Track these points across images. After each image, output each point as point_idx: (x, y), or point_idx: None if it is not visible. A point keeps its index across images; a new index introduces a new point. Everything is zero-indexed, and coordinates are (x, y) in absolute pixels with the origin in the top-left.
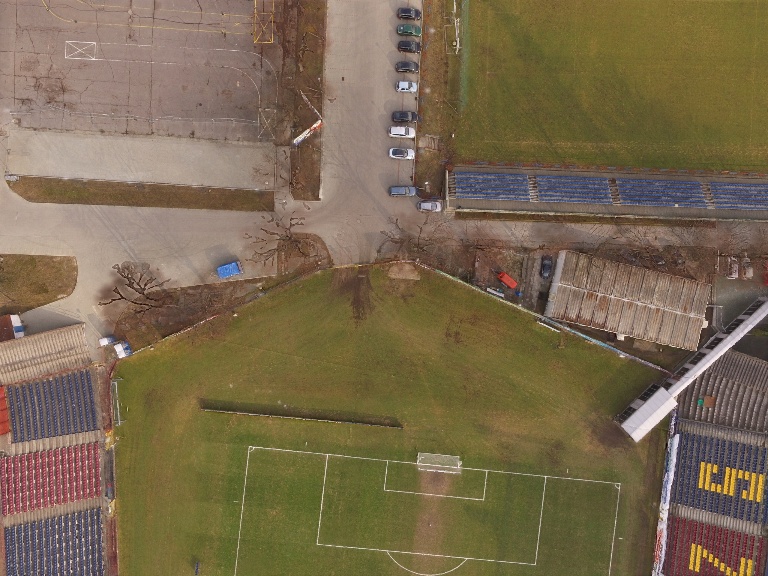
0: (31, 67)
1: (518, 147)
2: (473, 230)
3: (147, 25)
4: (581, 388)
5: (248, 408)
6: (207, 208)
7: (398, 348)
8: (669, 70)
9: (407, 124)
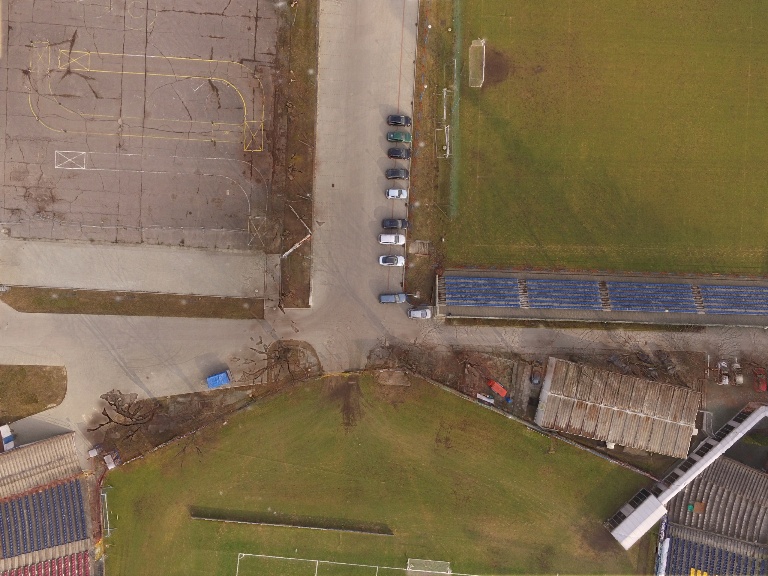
0: (21, 177)
1: (508, 250)
2: (463, 336)
3: (137, 134)
4: (571, 493)
5: (238, 515)
6: (197, 316)
7: (388, 454)
8: (659, 173)
9: (397, 230)
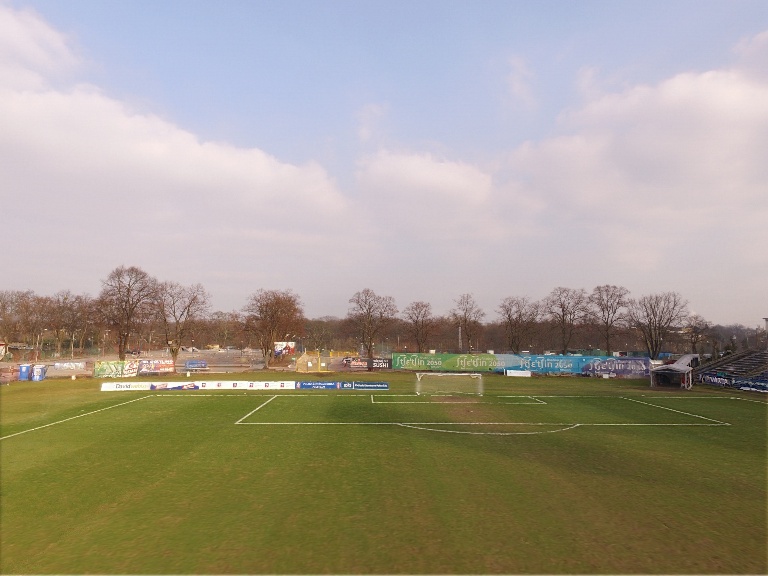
0: None
1: None
2: None
3: None
4: None
5: None
6: None
7: None
8: None
9: None
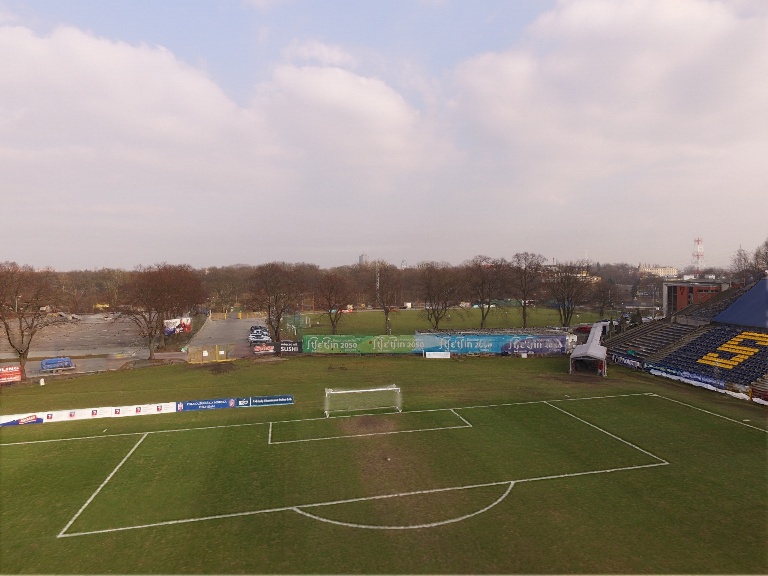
0: None
1: None
2: None
3: None
4: (508, 369)
5: None
6: None
7: None
8: None
9: None
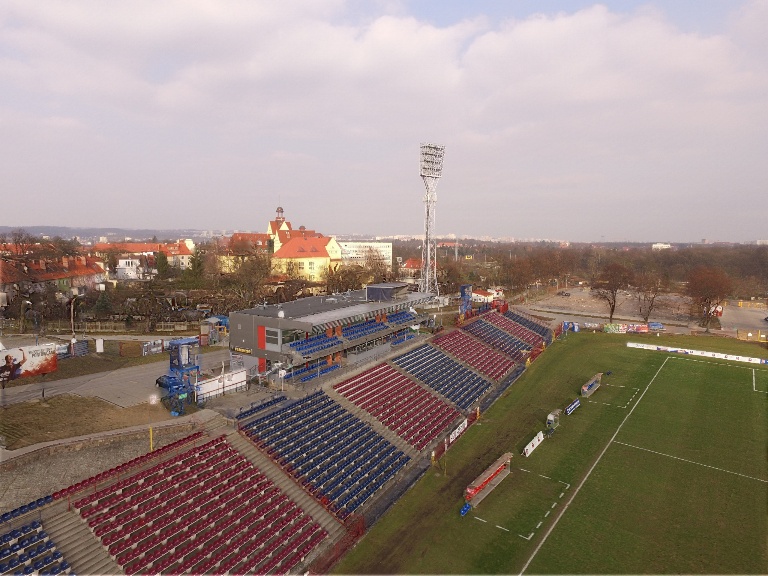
0: None
1: None
2: None
3: None
4: None
5: None
6: None
7: None
8: None
9: None
